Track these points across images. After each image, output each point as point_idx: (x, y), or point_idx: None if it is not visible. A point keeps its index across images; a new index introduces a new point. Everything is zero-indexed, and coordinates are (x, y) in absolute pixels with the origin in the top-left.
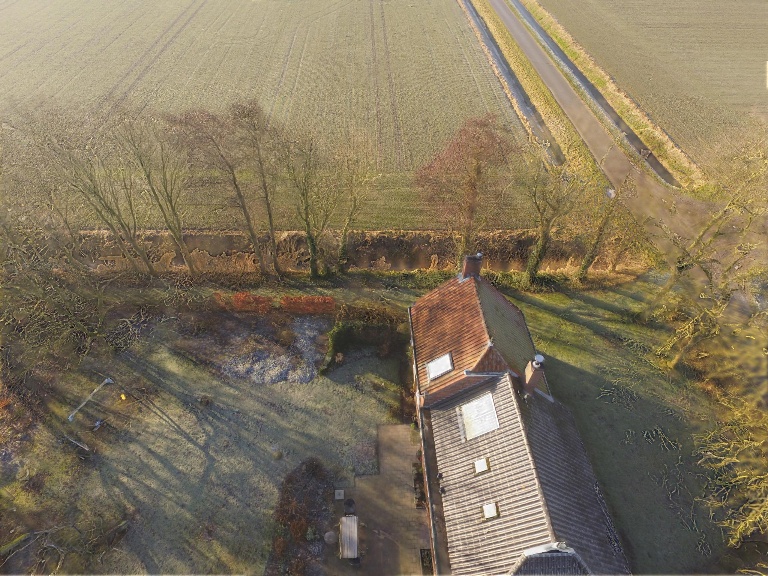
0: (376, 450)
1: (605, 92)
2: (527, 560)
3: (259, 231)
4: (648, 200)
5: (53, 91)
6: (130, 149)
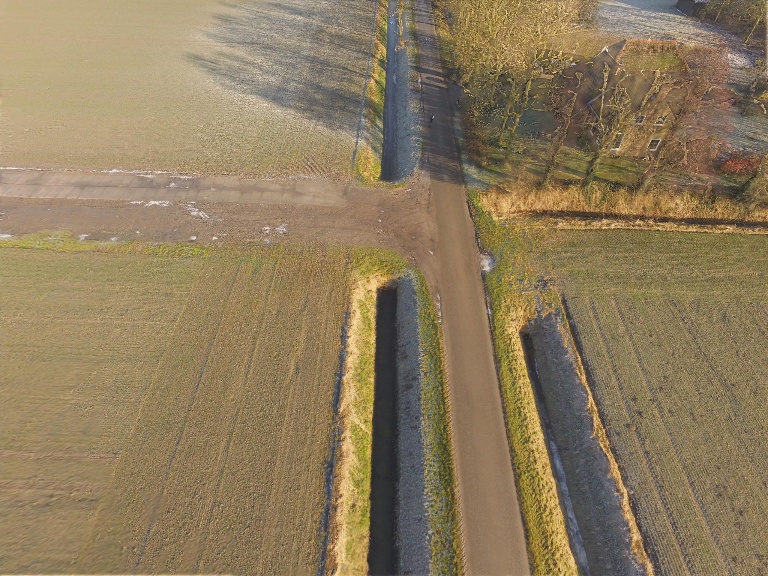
0: None
1: None
2: None
3: None
4: (450, 253)
5: None
6: None
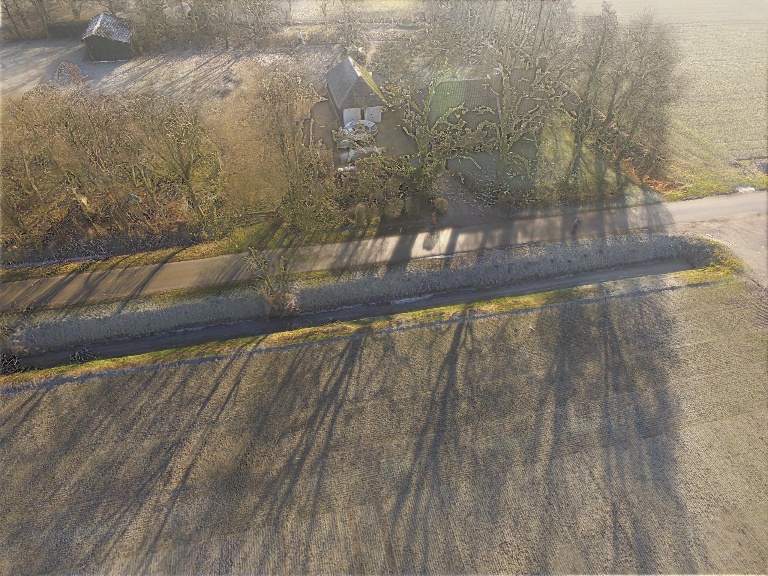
0: None
1: None
2: (427, 88)
3: None
4: (761, 205)
5: None
6: None
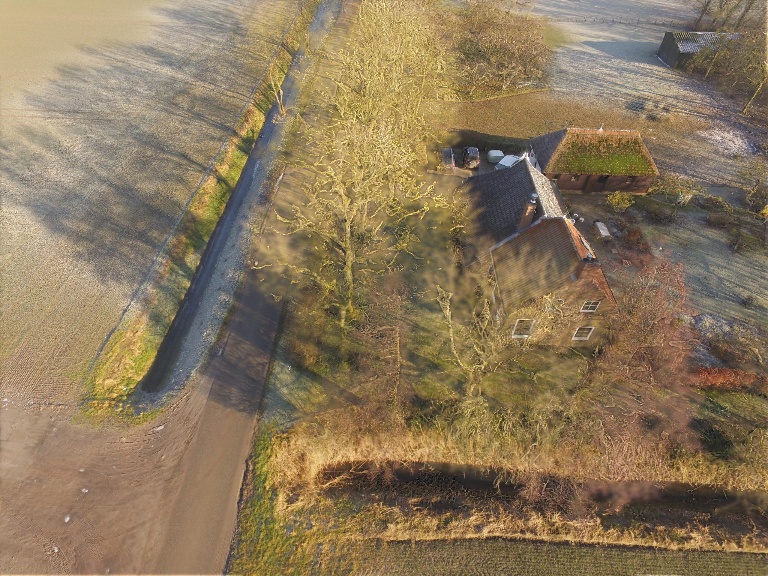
0: None
1: None
2: None
3: None
4: None
5: None
6: None
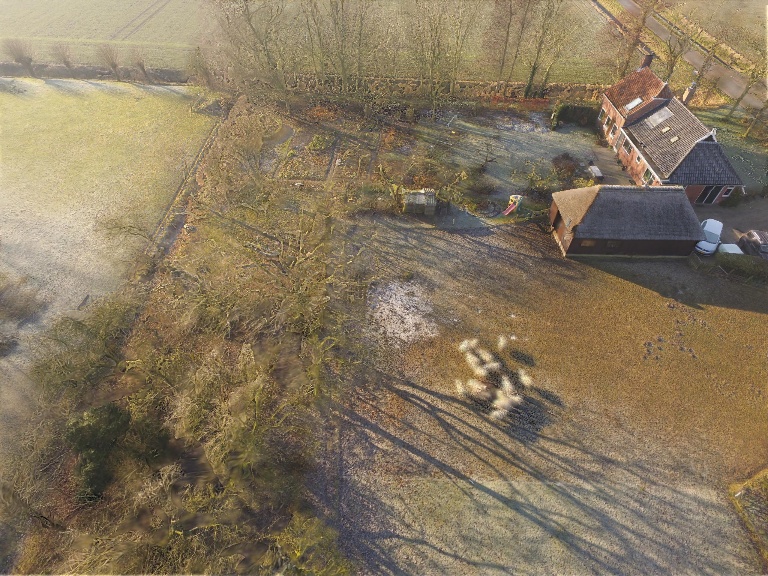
0: None
1: (680, 25)
2: (697, 144)
3: (480, 81)
4: (721, 76)
5: (295, 12)
6: (463, 1)
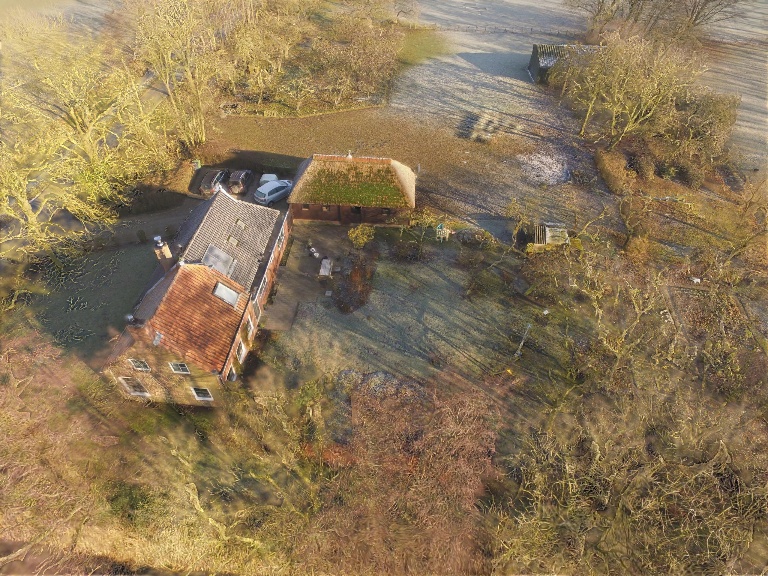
0: (297, 314)
1: None
2: None
3: None
4: None
5: None
6: None
